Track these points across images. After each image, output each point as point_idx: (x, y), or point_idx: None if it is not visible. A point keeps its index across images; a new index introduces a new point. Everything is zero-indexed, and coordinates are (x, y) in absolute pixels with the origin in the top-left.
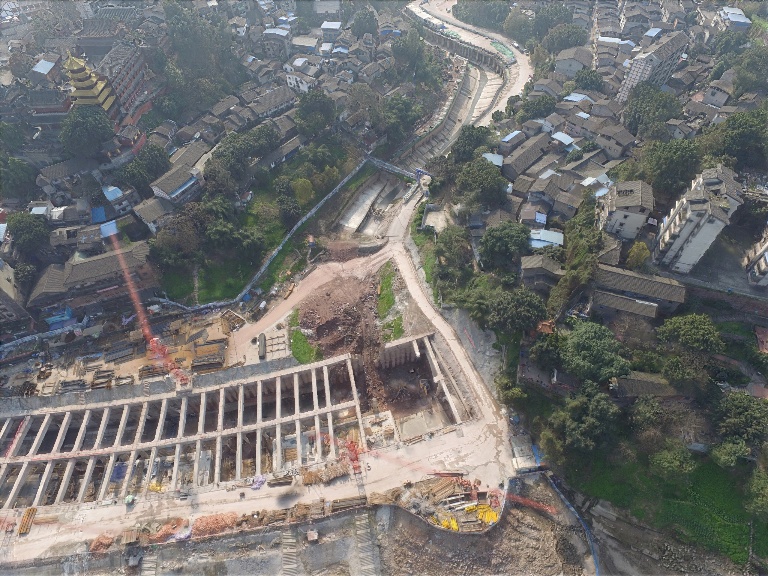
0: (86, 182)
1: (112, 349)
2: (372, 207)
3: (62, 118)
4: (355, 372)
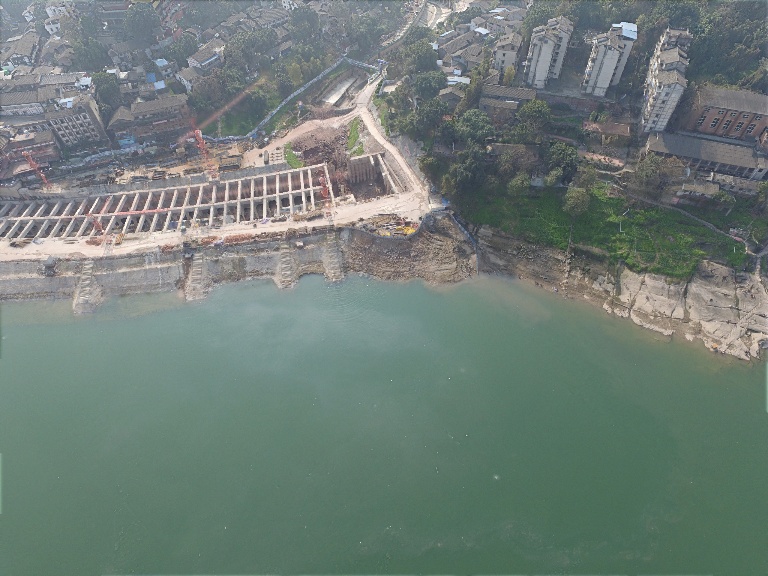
0: (141, 58)
1: (164, 161)
2: (346, 92)
3: (123, 14)
4: (331, 182)
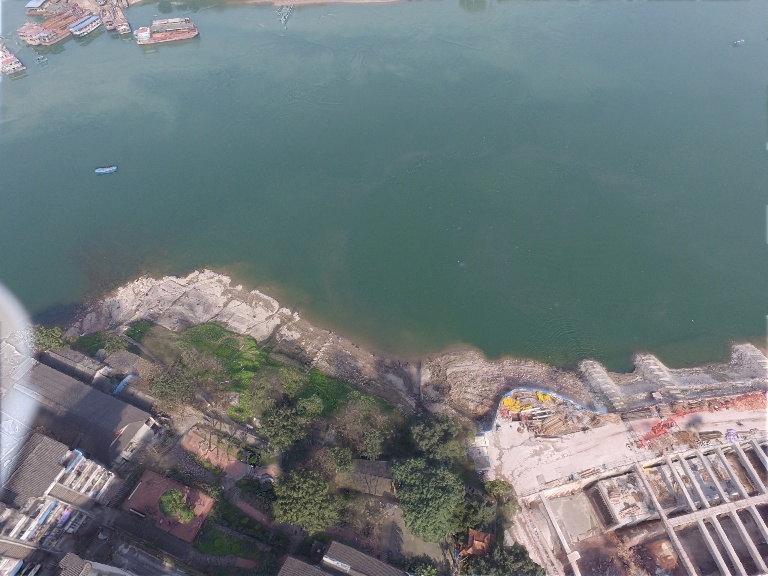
0: None
1: None
2: None
3: None
4: None
